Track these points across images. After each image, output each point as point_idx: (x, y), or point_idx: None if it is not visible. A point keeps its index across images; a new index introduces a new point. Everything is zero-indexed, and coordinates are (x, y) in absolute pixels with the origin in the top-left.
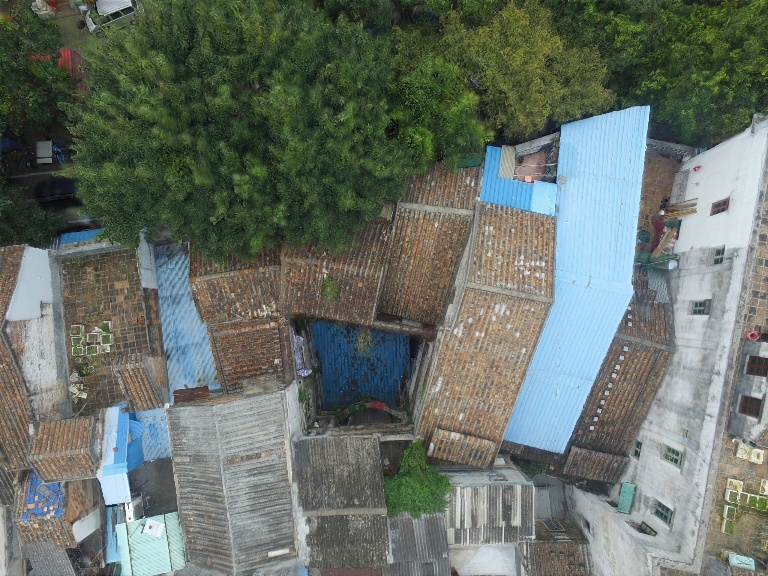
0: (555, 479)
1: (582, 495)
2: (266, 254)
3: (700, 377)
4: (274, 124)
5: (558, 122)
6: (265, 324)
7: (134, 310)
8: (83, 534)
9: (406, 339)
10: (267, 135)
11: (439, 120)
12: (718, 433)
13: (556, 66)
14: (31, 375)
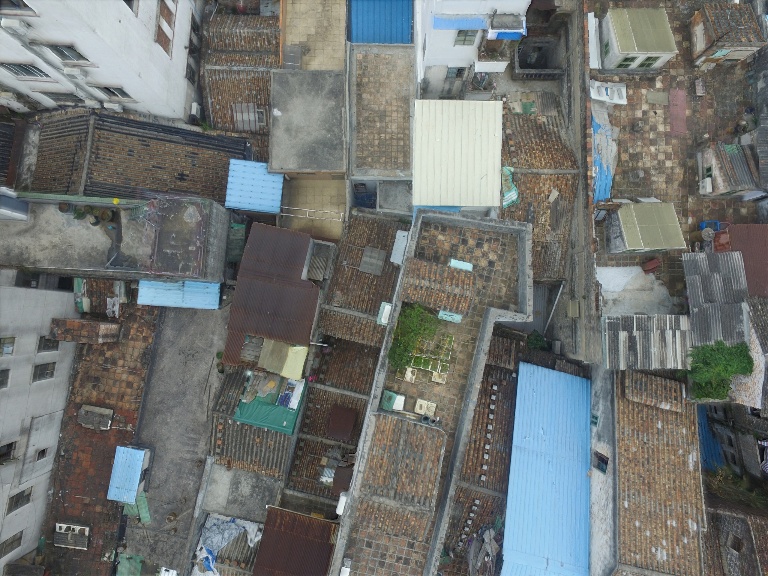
0: None
1: None
2: None
3: None
4: None
5: None
6: None
7: None
8: None
9: None
10: None
11: None
12: None
13: None
14: None
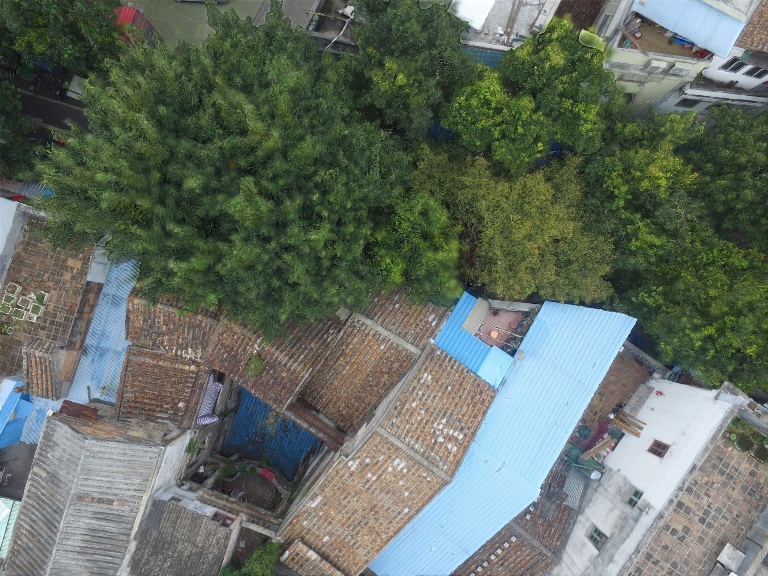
0: None
1: None
2: None
3: None
4: None
5: (542, 297)
6: (185, 365)
7: (75, 292)
8: None
9: None
10: None
11: (417, 263)
12: None
13: (562, 246)
14: None
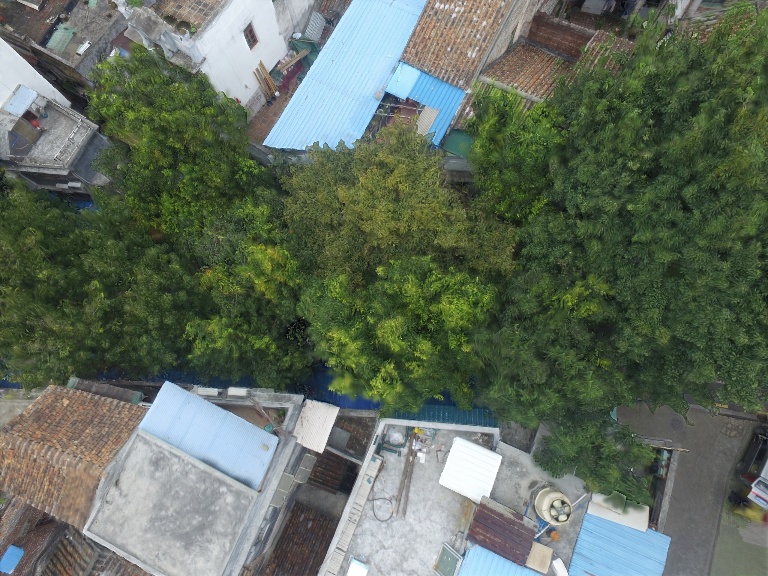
0: None
1: None
2: None
3: None
4: None
5: None
6: None
7: None
8: None
9: None
10: None
11: None
12: None
13: None
14: None
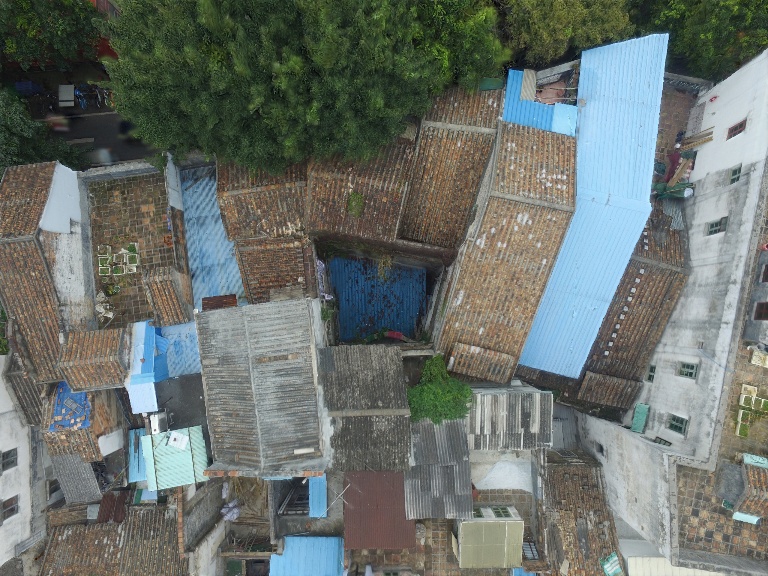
0: (568, 413)
1: (596, 421)
2: (292, 171)
3: (716, 290)
4: (310, 17)
5: (579, 48)
6: (289, 243)
7: (160, 232)
8: (108, 450)
9: (422, 276)
10: (300, 38)
11: (466, 31)
12: (734, 337)
13: None
14: (61, 286)
